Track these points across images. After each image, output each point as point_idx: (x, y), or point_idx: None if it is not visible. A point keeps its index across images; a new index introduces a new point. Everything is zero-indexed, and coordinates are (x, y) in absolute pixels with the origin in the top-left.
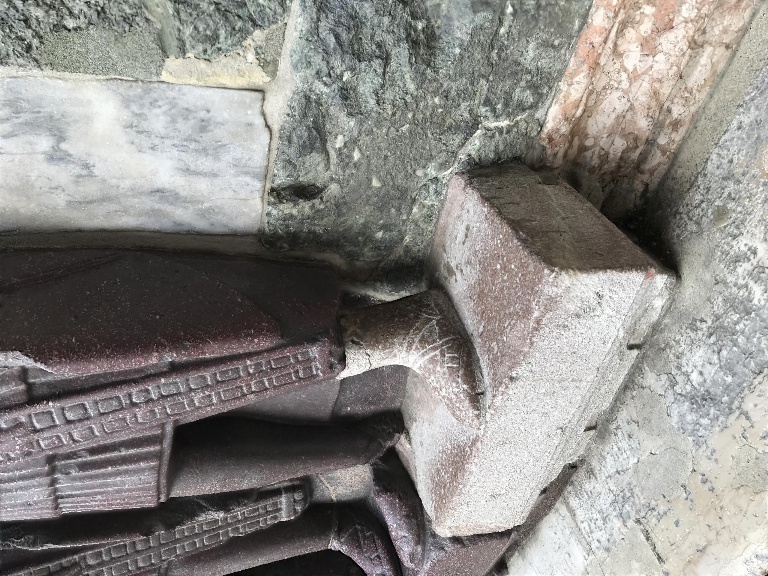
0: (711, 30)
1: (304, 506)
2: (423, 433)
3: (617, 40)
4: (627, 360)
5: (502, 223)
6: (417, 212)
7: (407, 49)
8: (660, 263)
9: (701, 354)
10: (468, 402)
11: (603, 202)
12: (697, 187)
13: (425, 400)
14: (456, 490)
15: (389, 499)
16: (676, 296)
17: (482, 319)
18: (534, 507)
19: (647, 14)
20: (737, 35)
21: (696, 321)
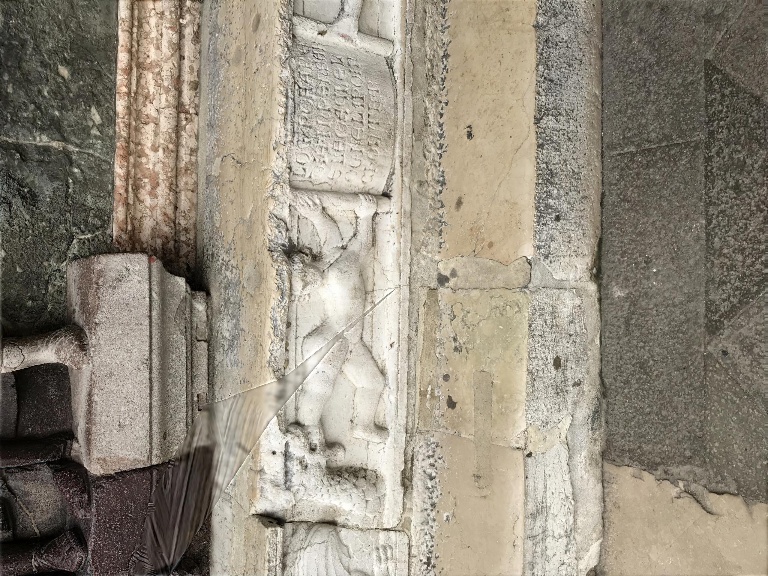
0: (180, 185)
1: (6, 524)
2: None
3: (137, 195)
4: (201, 350)
5: None
6: (51, 289)
7: (20, 199)
8: None
9: (225, 321)
10: (78, 348)
11: None
12: (205, 253)
13: None
14: (92, 422)
15: (63, 474)
16: (212, 305)
17: (83, 312)
18: None
19: (146, 182)
20: (194, 186)
21: (220, 309)
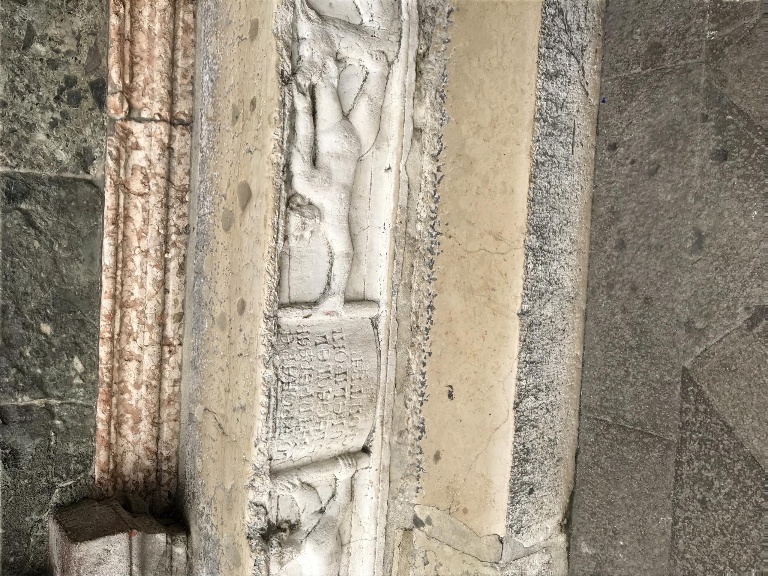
0: (163, 416)
1: None
2: None
3: (120, 431)
4: None
5: (62, 531)
6: (34, 541)
7: (2, 463)
8: (180, 530)
9: (205, 571)
10: None
11: (151, 507)
12: (186, 486)
13: None
14: None
15: None
16: (192, 545)
17: None
18: None
19: (129, 418)
20: (177, 415)
21: (200, 554)
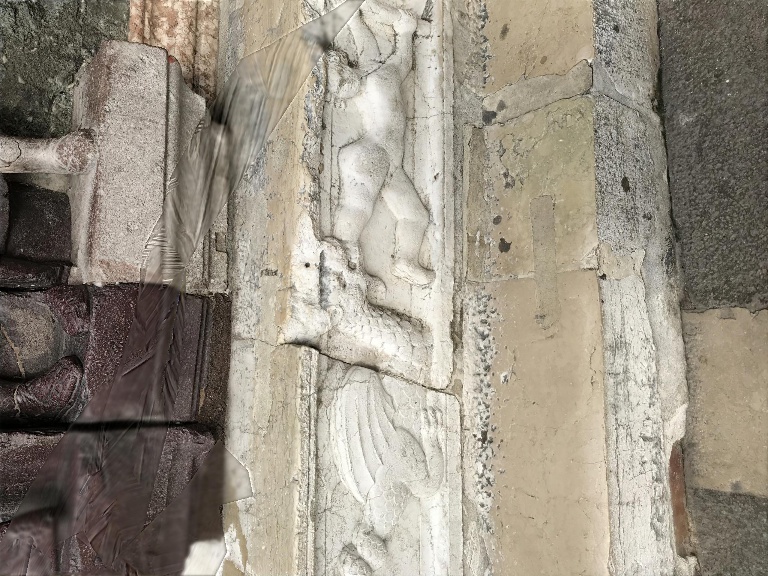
0: (200, 29)
1: None
2: (81, 241)
3: (154, 33)
4: None
5: None
6: (55, 110)
7: (27, 7)
8: None
9: None
10: (84, 137)
11: None
12: None
13: (80, 221)
14: (96, 219)
15: (57, 289)
16: None
17: (91, 111)
18: (198, 319)
19: (164, 21)
20: (215, 33)
21: None
